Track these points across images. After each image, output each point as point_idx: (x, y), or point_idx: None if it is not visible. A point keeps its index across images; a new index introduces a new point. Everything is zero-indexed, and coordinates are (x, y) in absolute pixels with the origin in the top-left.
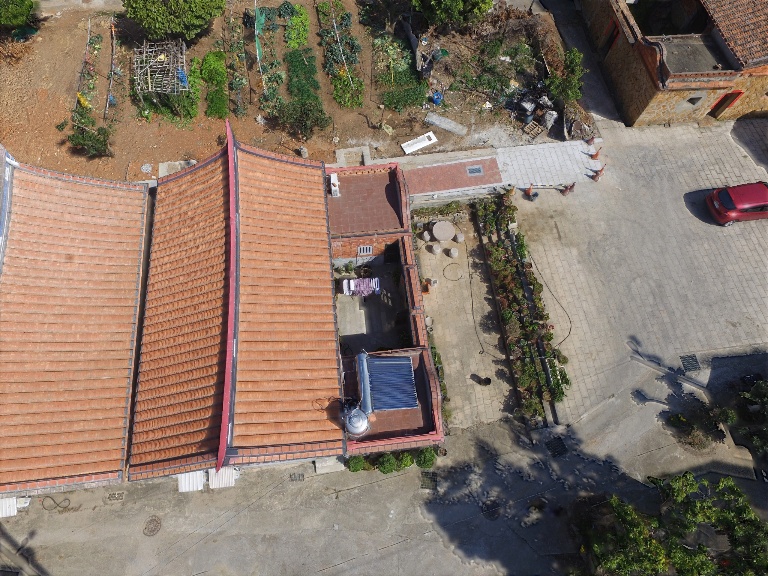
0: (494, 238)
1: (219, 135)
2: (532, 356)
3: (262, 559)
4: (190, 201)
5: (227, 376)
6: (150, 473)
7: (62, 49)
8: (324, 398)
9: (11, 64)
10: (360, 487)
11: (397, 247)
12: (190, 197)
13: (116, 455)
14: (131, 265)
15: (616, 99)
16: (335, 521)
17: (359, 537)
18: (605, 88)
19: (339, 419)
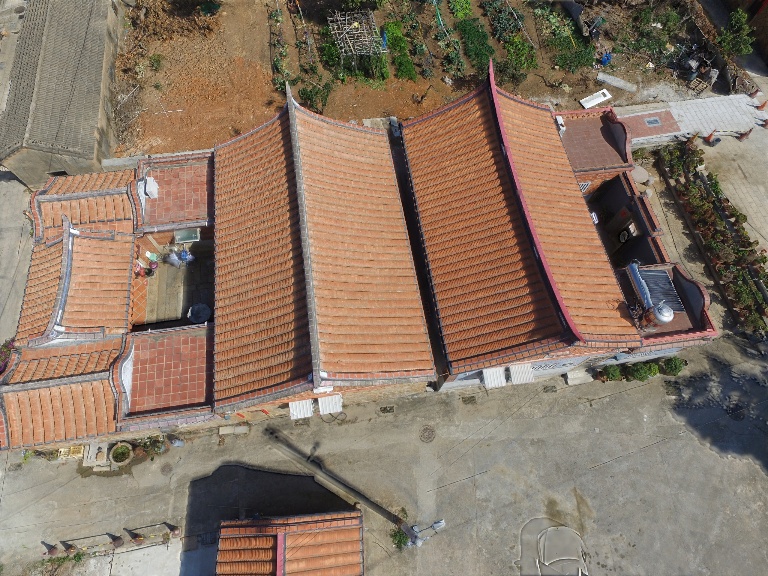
0: (682, 180)
1: (413, 94)
2: (745, 279)
3: (536, 459)
4: (444, 138)
5: (549, 273)
6: (475, 365)
7: (246, 22)
8: (612, 300)
9: (205, 35)
10: (610, 396)
11: (610, 185)
12: (444, 135)
13: (427, 356)
14: (392, 197)
15: (765, 59)
16: (595, 425)
17: (621, 438)
18: (753, 49)
19: (630, 318)
